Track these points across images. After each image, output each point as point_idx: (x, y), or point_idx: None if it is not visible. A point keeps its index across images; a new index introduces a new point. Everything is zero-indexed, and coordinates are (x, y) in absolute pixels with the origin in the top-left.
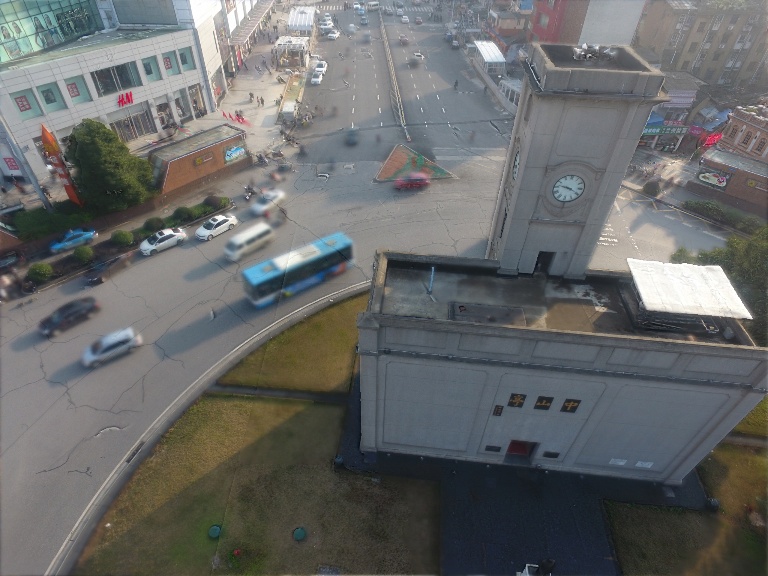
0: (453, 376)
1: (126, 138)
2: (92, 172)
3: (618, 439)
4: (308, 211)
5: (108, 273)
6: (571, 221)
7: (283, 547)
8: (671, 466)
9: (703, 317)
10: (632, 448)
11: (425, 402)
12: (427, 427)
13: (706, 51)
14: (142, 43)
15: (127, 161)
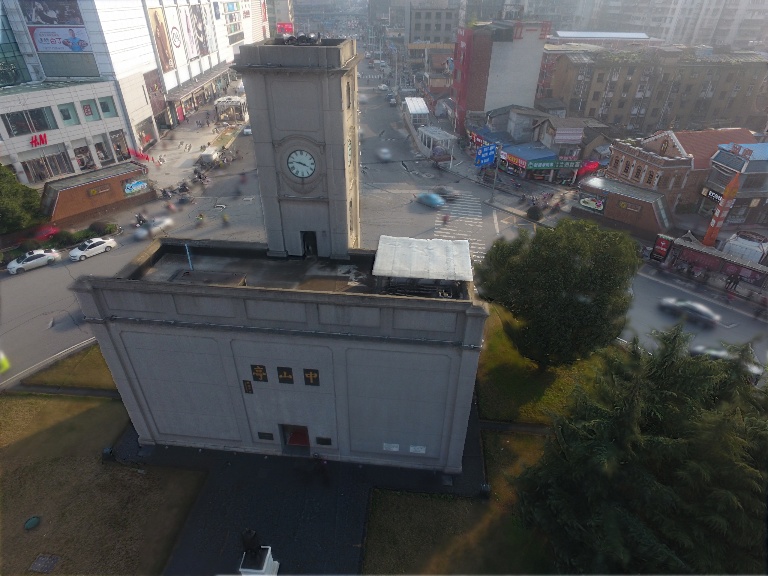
0: (187, 346)
1: (40, 176)
2: None
3: (377, 418)
4: (191, 235)
5: None
6: (316, 197)
7: (9, 536)
8: (443, 450)
9: (445, 287)
10: (396, 429)
11: (177, 380)
12: (192, 412)
13: (610, 99)
14: (58, 91)
15: (8, 187)
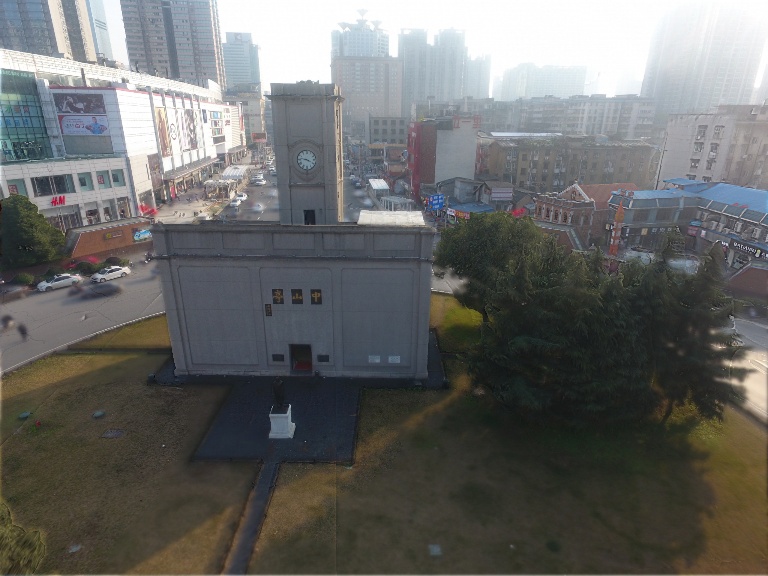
0: (227, 276)
1: None
2: (9, 230)
3: (363, 331)
4: None
5: (2, 299)
6: (316, 184)
7: (81, 422)
8: (413, 357)
9: None
10: (377, 340)
11: (214, 308)
12: (222, 339)
13: (535, 174)
14: (80, 162)
15: (42, 225)
